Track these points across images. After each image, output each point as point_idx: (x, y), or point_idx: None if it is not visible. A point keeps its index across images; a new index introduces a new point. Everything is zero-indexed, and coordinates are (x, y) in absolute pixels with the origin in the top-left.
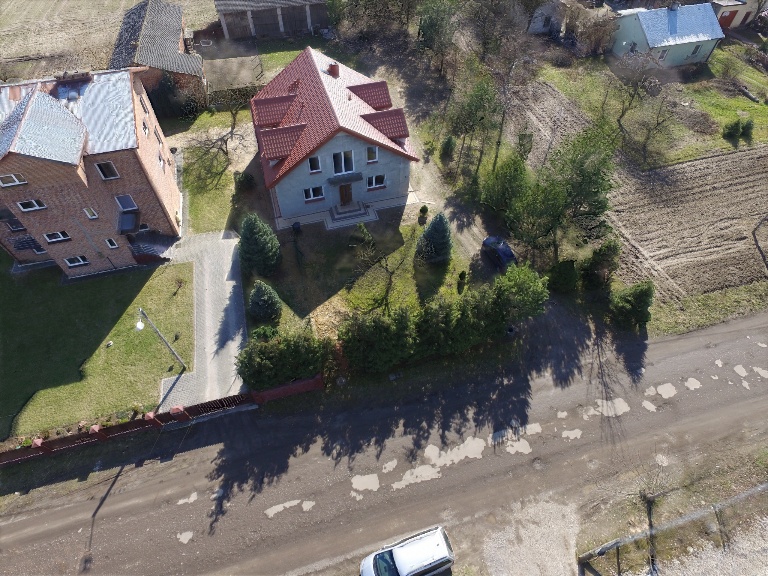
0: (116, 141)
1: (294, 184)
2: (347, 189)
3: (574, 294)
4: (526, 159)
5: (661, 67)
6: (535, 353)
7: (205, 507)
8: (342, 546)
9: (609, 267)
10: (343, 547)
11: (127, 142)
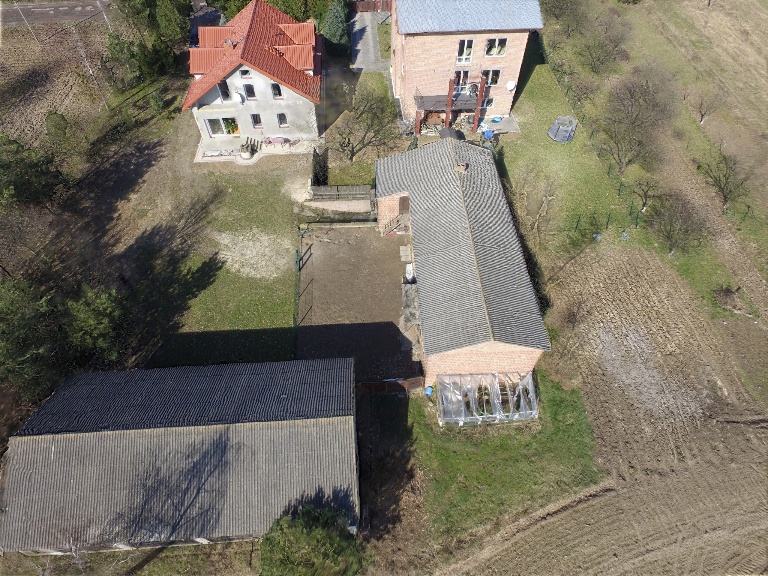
0: None
1: None
2: None
3: None
4: None
5: None
6: (220, 16)
7: None
8: None
9: None
10: None
11: None
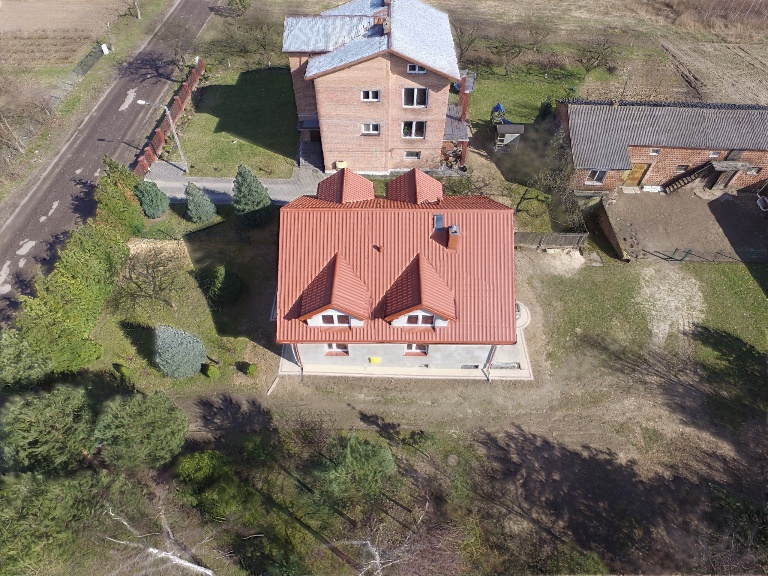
0: (315, 67)
1: None
2: None
3: None
4: None
5: None
6: None
7: (87, 178)
8: (7, 231)
9: None
10: (6, 231)
11: (311, 72)
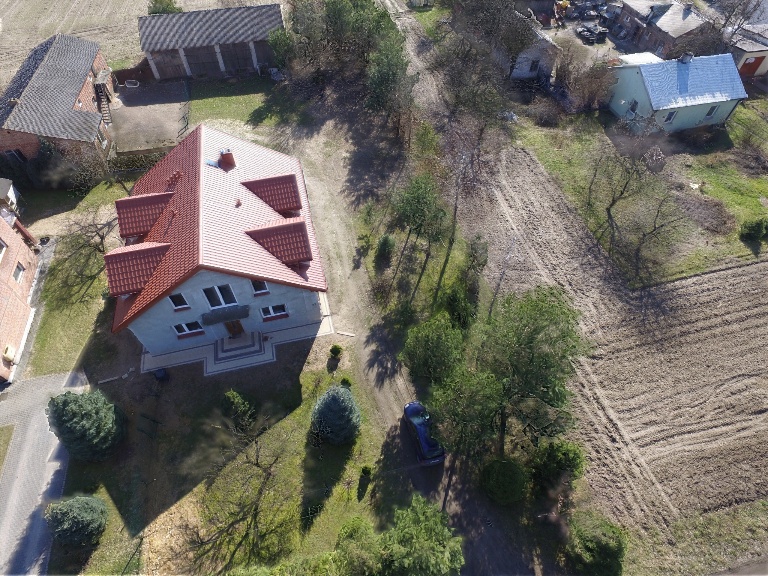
0: None
1: (155, 322)
2: (234, 321)
3: (519, 507)
4: (481, 272)
5: (666, 135)
6: None
7: None
8: None
9: (568, 477)
10: None
11: None
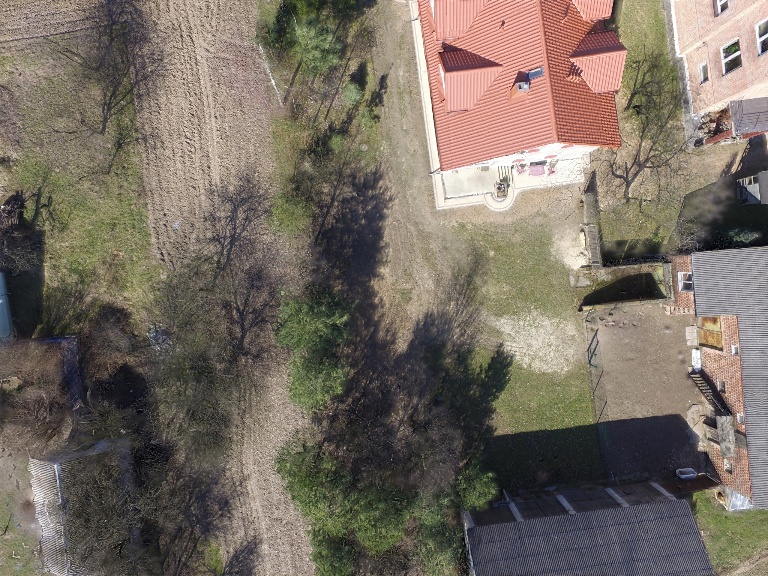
0: None
1: None
2: None
3: None
4: None
5: None
6: None
7: None
8: None
9: None
10: None
11: None
